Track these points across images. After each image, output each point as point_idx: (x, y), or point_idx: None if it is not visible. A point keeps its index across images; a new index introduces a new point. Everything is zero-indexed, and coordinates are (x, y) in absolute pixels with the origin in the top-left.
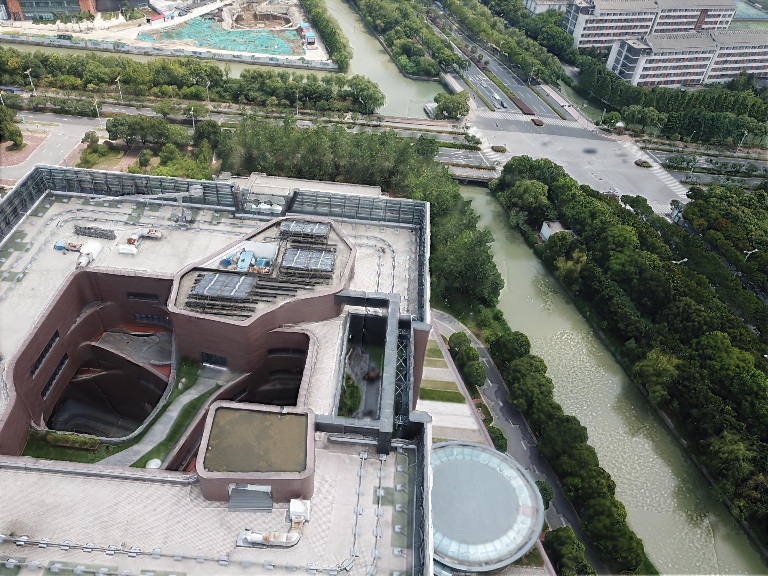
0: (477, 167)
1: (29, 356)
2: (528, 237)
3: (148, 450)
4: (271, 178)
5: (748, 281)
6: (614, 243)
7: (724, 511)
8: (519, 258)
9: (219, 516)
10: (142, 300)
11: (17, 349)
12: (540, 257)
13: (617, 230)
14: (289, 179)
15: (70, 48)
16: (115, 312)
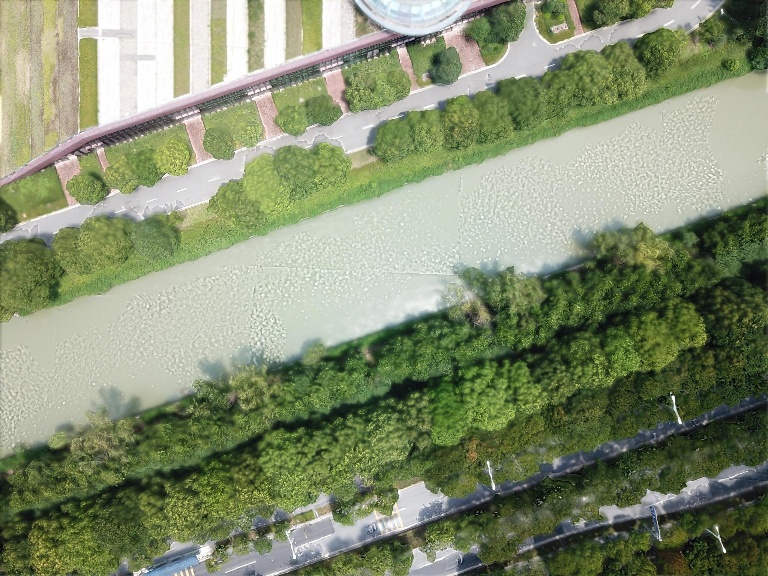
0: None
1: None
2: None
3: None
4: None
5: None
6: None
7: None
8: None
9: None
10: None
11: None
12: None
13: None
14: None
15: None
16: None
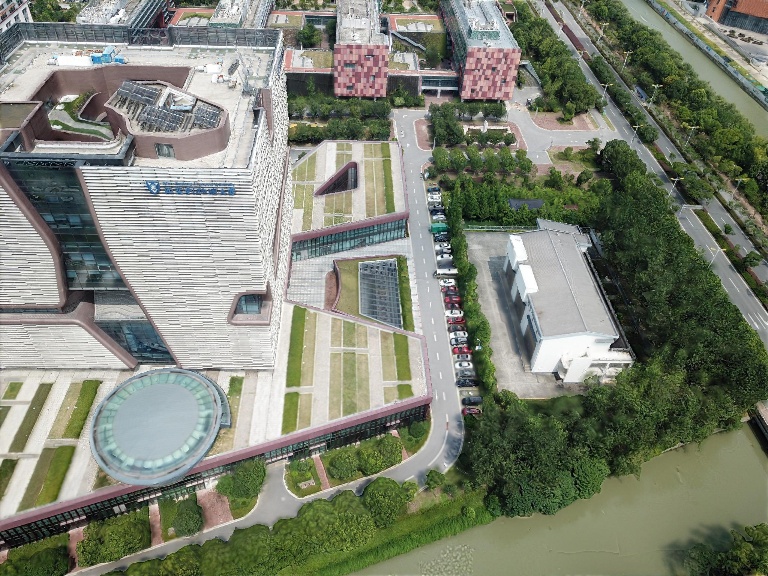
0: None
1: (128, 72)
2: None
3: (69, 125)
4: (576, 244)
5: None
6: None
7: None
8: (639, 575)
9: None
10: None
11: (125, 64)
12: None
13: None
14: (583, 257)
15: (760, 103)
16: None
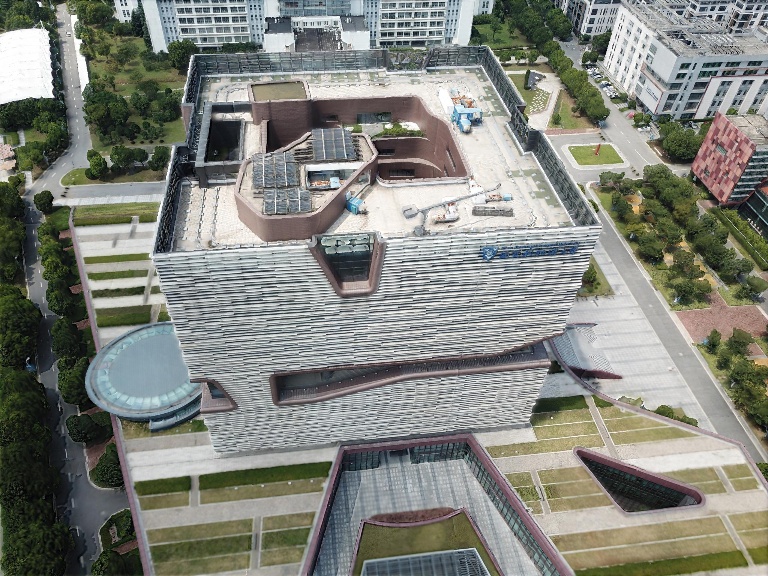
0: None
1: None
2: None
3: None
4: None
5: None
6: None
7: None
8: None
9: None
10: None
11: None
12: None
13: None
14: None
15: None
16: None
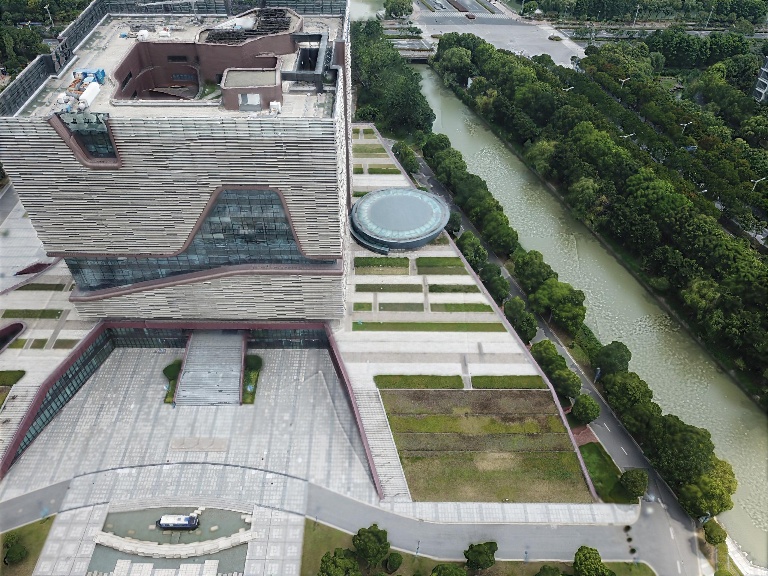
0: (419, 50)
1: (120, 76)
2: (458, 91)
3: None
4: None
5: (627, 106)
6: (517, 80)
7: (586, 231)
8: (451, 107)
9: (235, 114)
10: (177, 62)
11: (113, 69)
12: (467, 104)
13: (519, 70)
14: None
15: None
16: (161, 74)
